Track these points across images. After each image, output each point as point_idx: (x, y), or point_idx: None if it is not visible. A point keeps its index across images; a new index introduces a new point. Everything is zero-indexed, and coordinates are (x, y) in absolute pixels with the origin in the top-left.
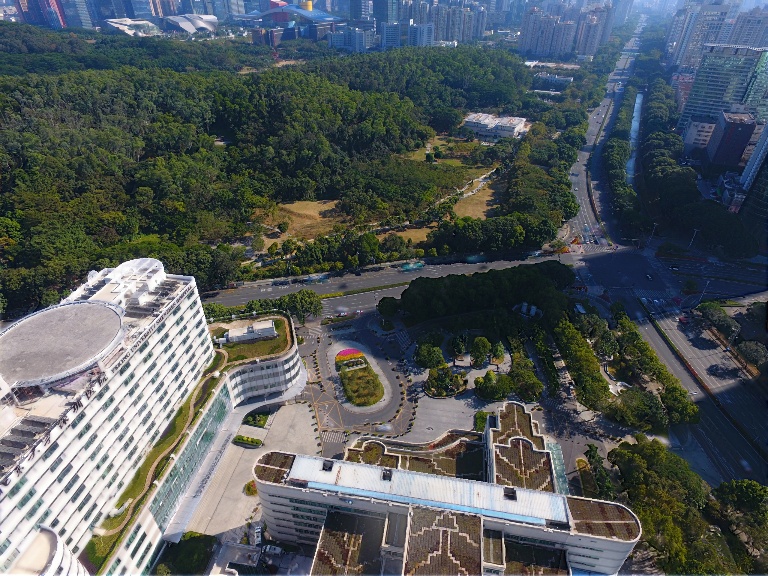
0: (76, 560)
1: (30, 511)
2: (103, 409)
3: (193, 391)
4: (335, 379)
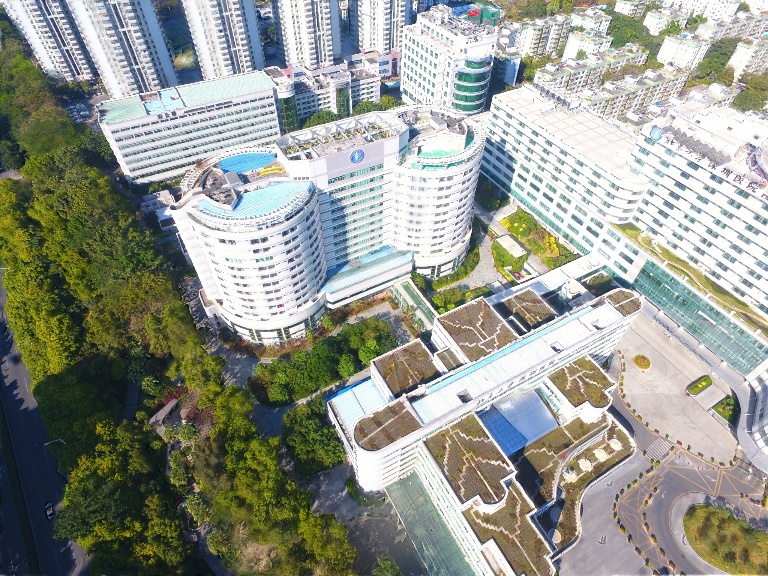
0: (625, 208)
1: (659, 171)
2: (729, 201)
3: None
4: (761, 526)
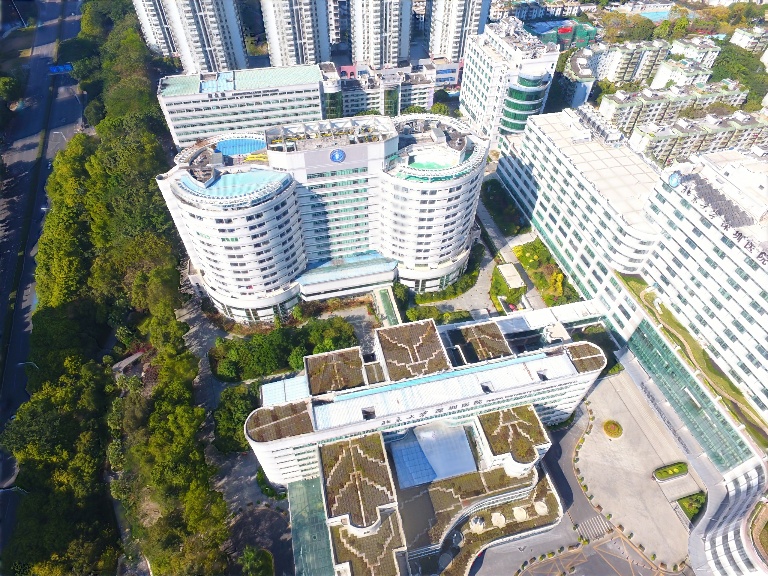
0: (632, 257)
1: (672, 222)
2: (738, 270)
3: (762, 419)
4: None
